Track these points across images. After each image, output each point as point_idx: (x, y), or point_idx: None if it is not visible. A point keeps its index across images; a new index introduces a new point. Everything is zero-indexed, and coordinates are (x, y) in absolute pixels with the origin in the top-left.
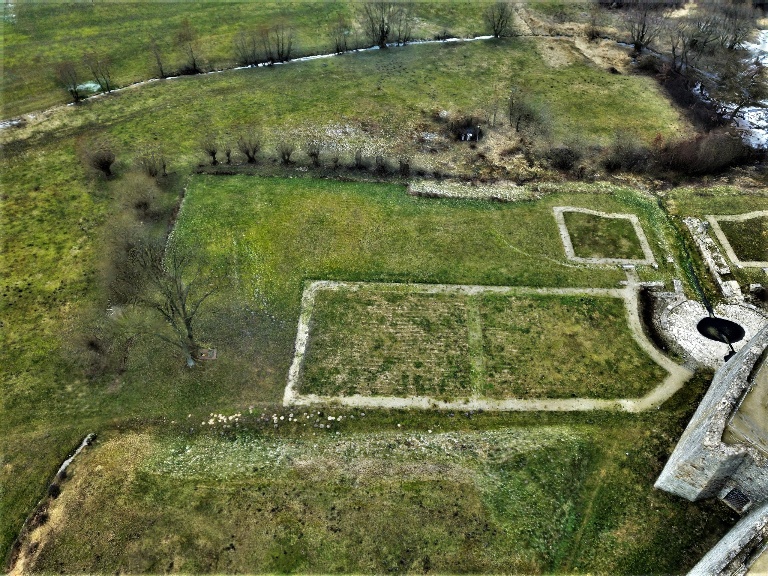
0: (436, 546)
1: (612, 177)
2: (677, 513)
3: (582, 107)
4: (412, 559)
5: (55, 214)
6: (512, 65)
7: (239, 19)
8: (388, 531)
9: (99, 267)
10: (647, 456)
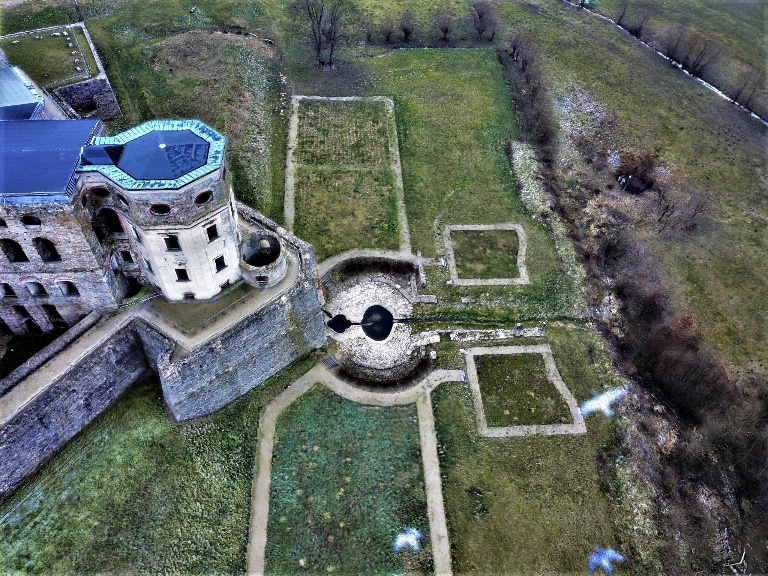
0: None
1: (611, 292)
2: None
3: (743, 274)
4: (180, 116)
5: (437, 13)
6: None
7: (741, 39)
8: (196, 109)
9: (395, 33)
10: None
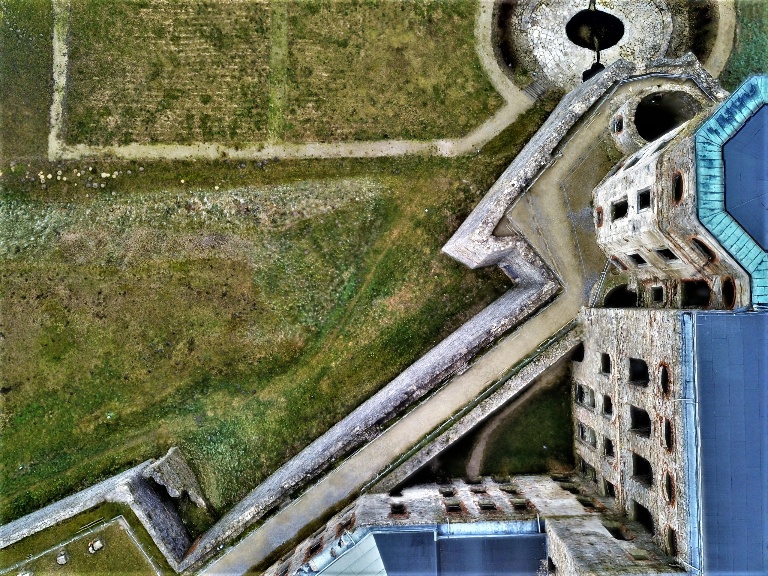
0: (202, 328)
1: None
2: (453, 280)
3: None
4: (177, 341)
5: None
6: None
7: None
8: (154, 316)
9: None
10: (446, 214)
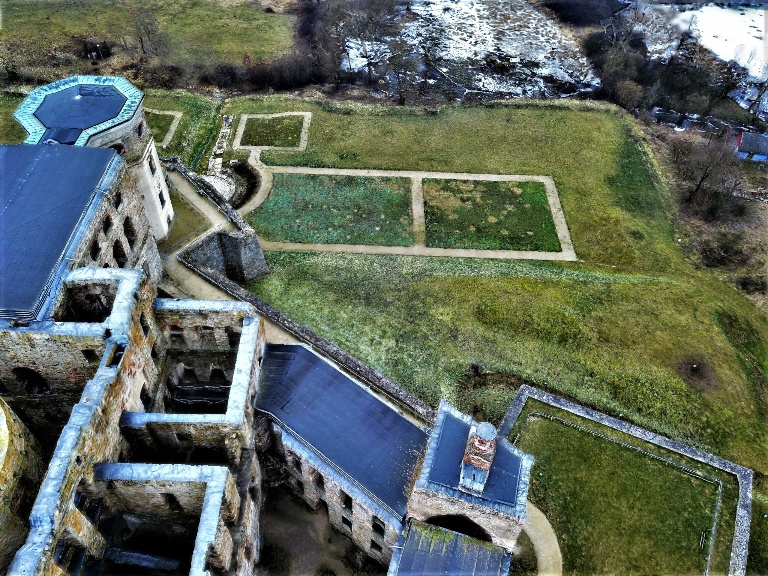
0: None
1: (201, 89)
2: None
3: (213, 36)
4: None
5: None
6: (185, 4)
7: None
8: None
9: None
10: None
